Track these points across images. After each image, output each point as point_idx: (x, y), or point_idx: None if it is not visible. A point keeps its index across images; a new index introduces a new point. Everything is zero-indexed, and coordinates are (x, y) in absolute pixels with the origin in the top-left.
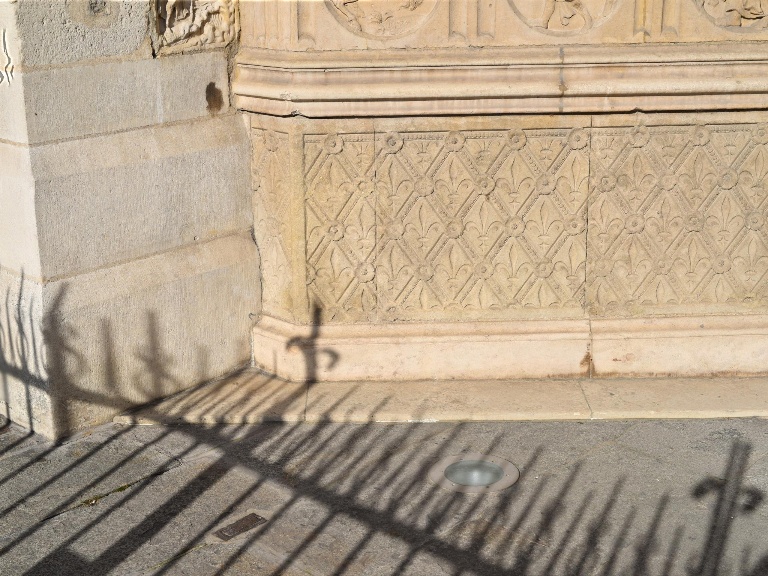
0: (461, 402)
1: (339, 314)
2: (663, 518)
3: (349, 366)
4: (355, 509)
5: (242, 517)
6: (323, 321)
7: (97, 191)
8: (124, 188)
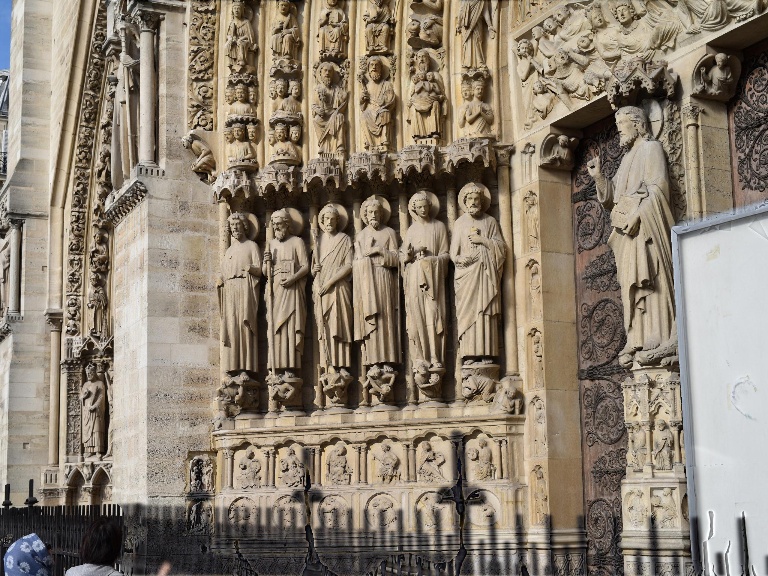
0: None
1: None
2: None
3: None
4: None
5: None
6: None
7: (164, 569)
8: (172, 570)
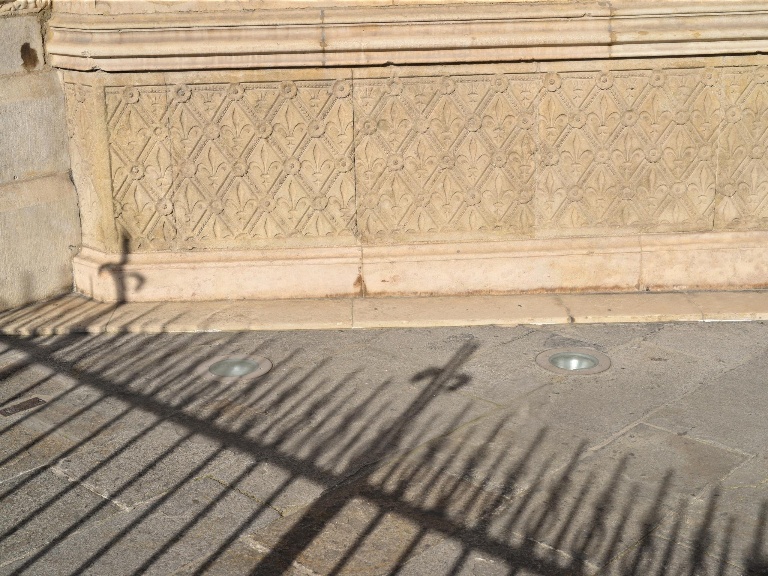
0: (244, 316)
1: (144, 244)
2: (376, 396)
3: (153, 288)
4: (123, 393)
5: (26, 400)
6: (131, 250)
7: None
8: None
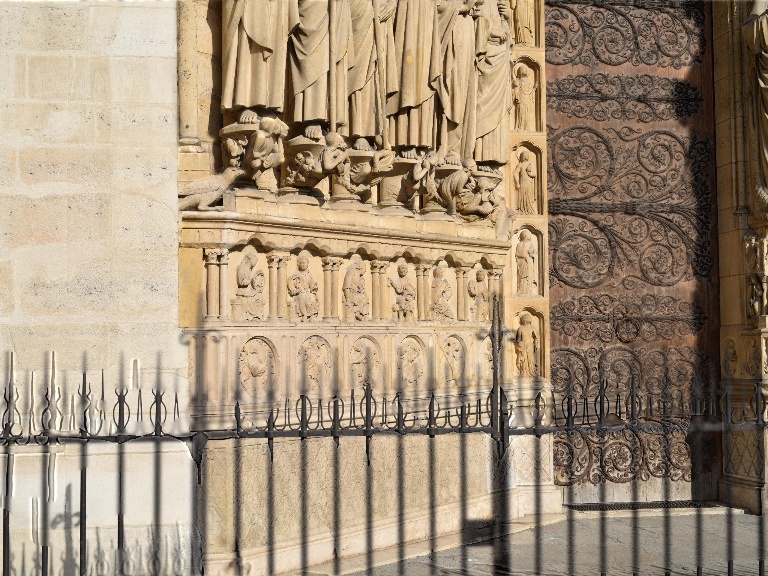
0: None
1: (245, 544)
2: None
3: (255, 571)
4: None
5: None
6: (239, 549)
7: None
8: None
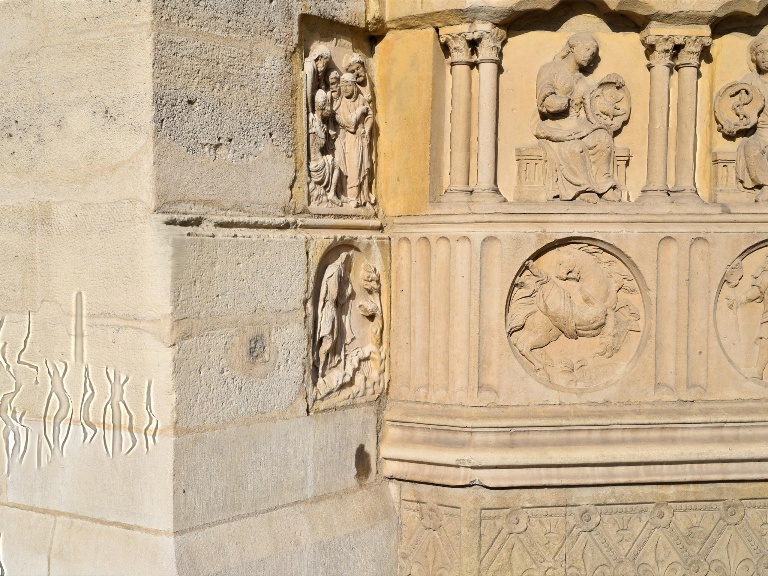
0: None
1: None
2: None
3: None
4: None
5: None
6: None
7: None
8: None
